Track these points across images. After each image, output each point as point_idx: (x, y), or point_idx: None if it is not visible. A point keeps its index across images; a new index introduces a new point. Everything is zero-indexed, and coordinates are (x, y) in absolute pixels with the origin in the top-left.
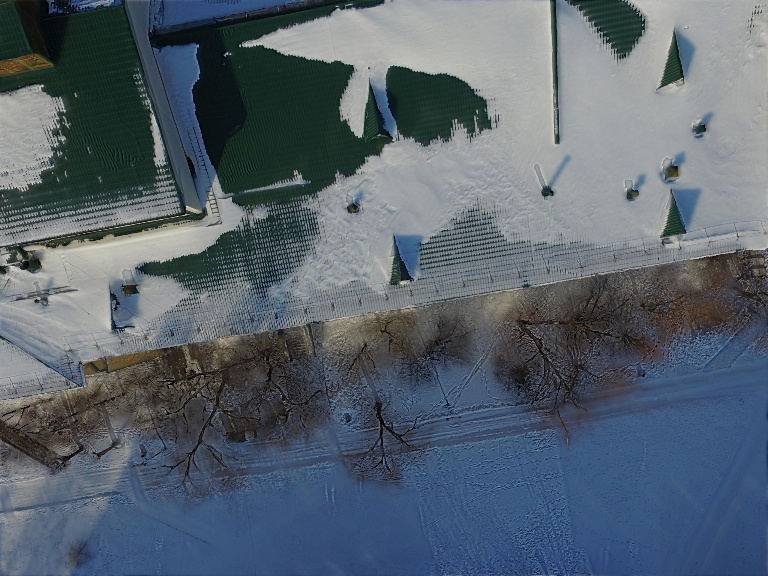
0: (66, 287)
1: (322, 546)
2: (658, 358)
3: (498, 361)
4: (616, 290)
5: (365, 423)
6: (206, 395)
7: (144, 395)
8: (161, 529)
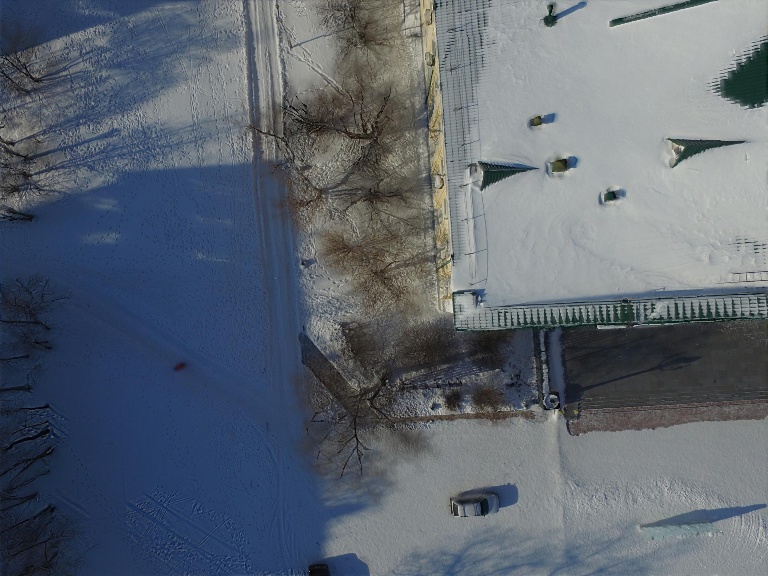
0: None
1: None
2: (321, 283)
3: None
4: (402, 245)
5: None
6: None
7: None
8: None
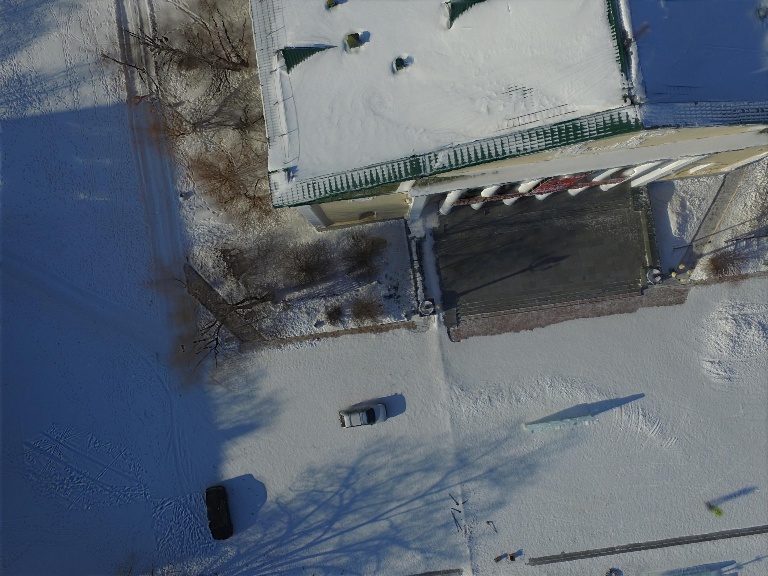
0: None
1: None
2: (201, 214)
3: None
4: None
5: None
6: None
7: None
8: None
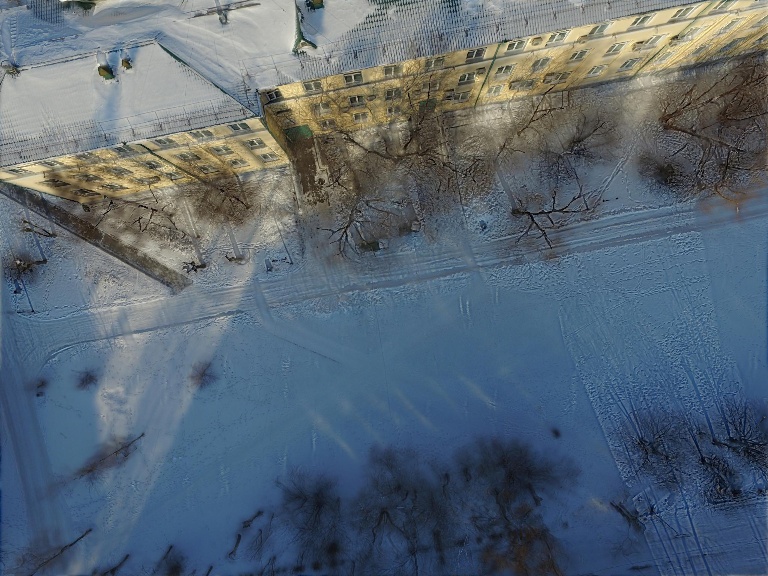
0: (248, 1)
1: (457, 361)
2: None
3: (641, 160)
4: (761, 86)
5: (501, 231)
6: (334, 207)
7: (270, 208)
8: (287, 349)
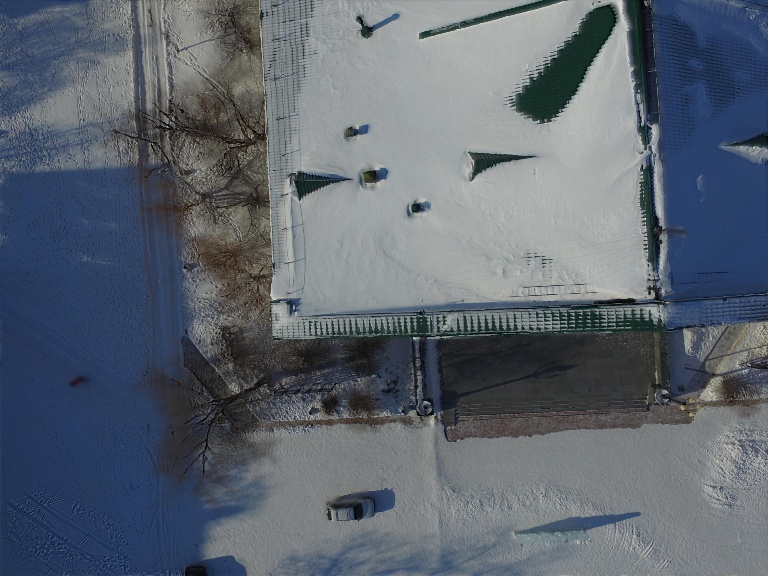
0: None
1: None
2: (203, 287)
3: None
4: None
5: None
6: None
7: None
8: None
